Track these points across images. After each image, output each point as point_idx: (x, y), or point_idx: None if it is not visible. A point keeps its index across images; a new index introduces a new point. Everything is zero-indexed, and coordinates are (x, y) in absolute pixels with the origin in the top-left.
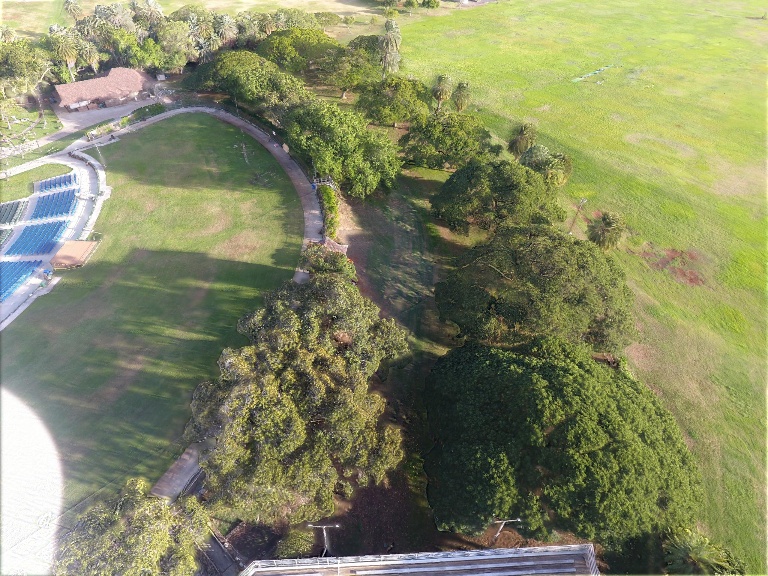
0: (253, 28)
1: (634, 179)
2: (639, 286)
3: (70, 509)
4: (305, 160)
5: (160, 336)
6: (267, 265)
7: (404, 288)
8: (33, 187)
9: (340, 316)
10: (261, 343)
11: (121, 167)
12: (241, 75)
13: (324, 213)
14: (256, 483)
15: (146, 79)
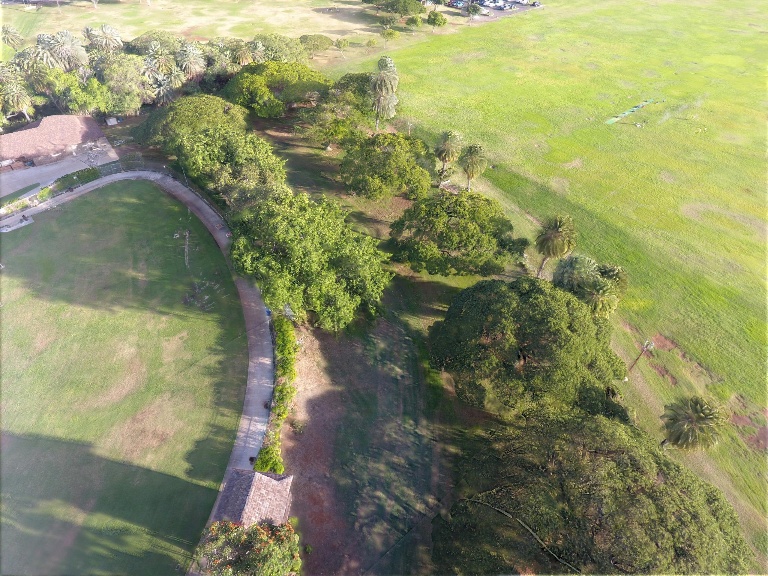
0: (224, 60)
1: (703, 280)
2: (738, 488)
3: None
4: None
5: None
6: (178, 477)
7: (387, 500)
8: None
9: None
10: None
11: (22, 268)
12: (184, 143)
13: None
14: None
15: (87, 129)
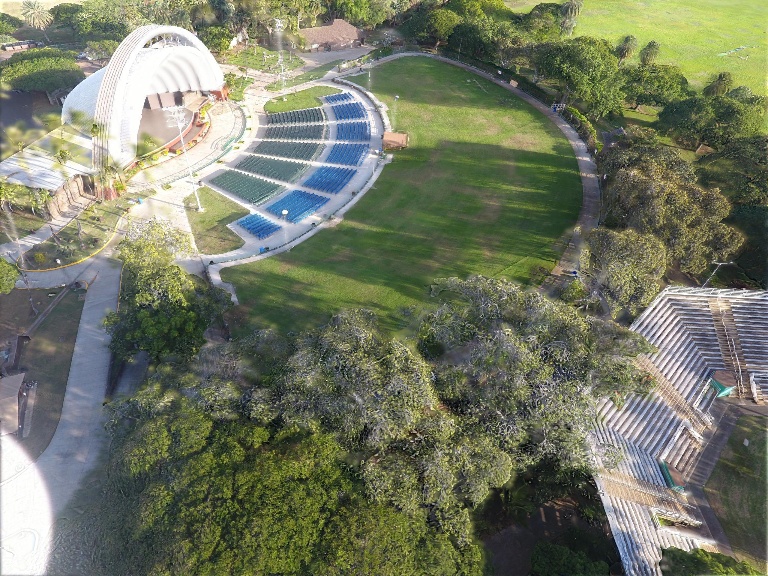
0: None
1: None
2: None
3: (514, 264)
4: (541, 90)
5: (500, 189)
6: (552, 154)
7: None
8: (320, 100)
9: (678, 163)
10: (639, 170)
11: (383, 90)
12: (478, 23)
13: (574, 126)
14: (679, 234)
15: None
